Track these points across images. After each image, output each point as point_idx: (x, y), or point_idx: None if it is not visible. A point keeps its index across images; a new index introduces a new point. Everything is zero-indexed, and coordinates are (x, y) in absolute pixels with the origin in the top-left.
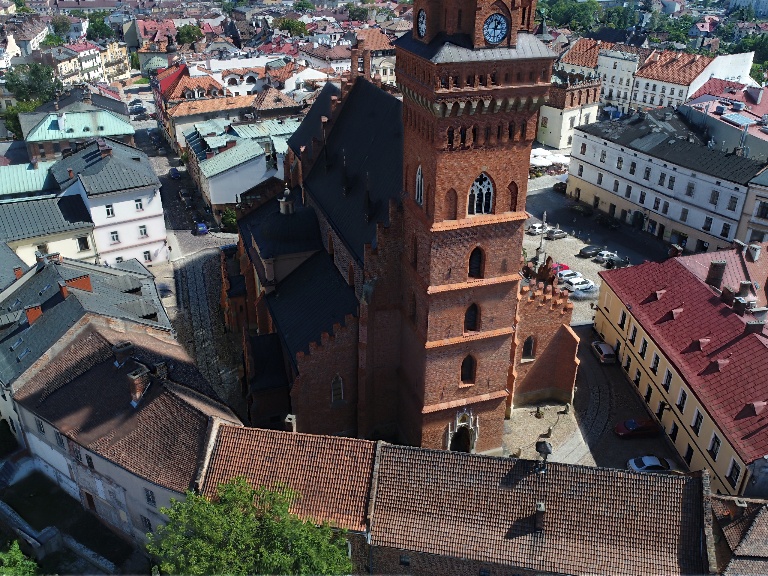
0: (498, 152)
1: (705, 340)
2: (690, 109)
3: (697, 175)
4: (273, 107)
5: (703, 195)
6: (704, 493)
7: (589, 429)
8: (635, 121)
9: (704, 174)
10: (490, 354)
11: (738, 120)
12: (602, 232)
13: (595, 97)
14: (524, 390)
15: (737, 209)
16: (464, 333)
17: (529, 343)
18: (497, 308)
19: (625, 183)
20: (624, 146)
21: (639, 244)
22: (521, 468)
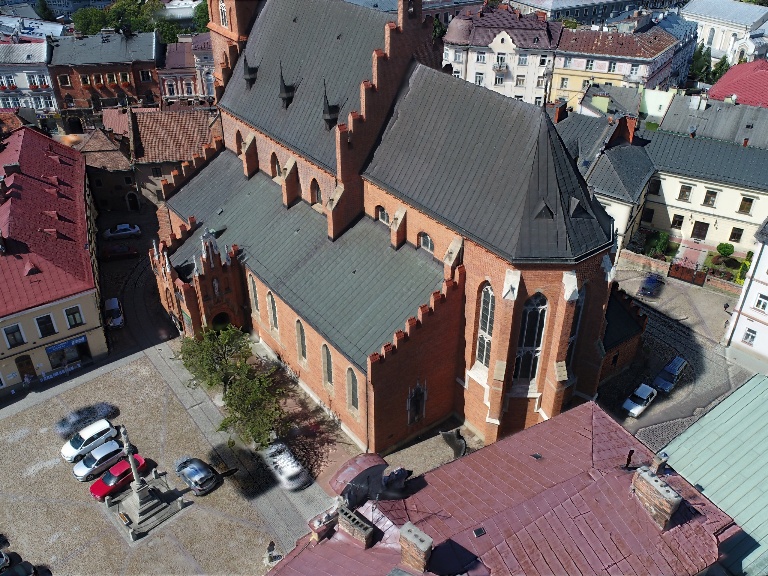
0: None
1: (52, 189)
2: None
3: None
4: None
5: None
6: None
7: None
8: None
9: None
10: None
11: None
12: None
13: None
14: None
15: None
16: None
17: None
18: None
19: None
20: None
21: None
22: None
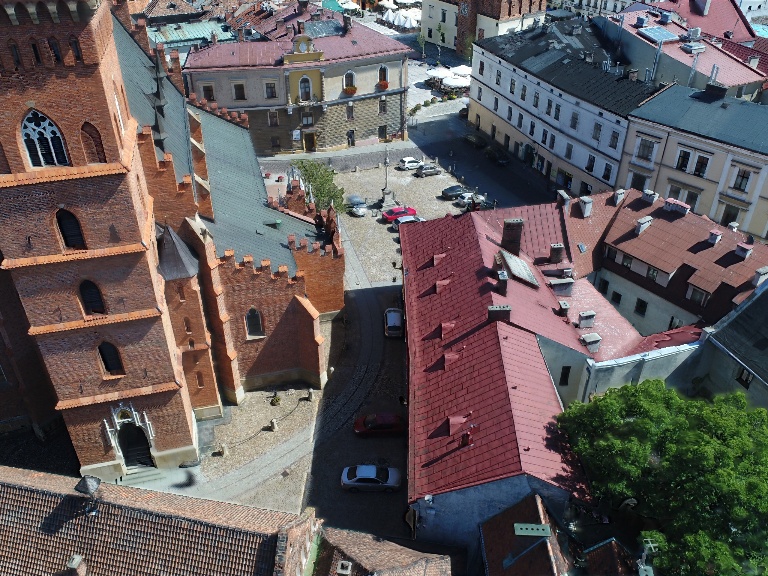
0: (46, 81)
1: (448, 325)
2: (605, 21)
3: (580, 103)
4: (165, 14)
5: (586, 128)
6: (276, 559)
7: (327, 422)
8: (537, 35)
9: (586, 102)
10: (136, 341)
11: (656, 35)
12: (486, 168)
13: (540, 5)
14: (261, 371)
15: (618, 147)
16: (86, 316)
17: (255, 317)
18: (124, 286)
19: (517, 110)
20: (515, 66)
21: (522, 184)
22: (68, 507)
